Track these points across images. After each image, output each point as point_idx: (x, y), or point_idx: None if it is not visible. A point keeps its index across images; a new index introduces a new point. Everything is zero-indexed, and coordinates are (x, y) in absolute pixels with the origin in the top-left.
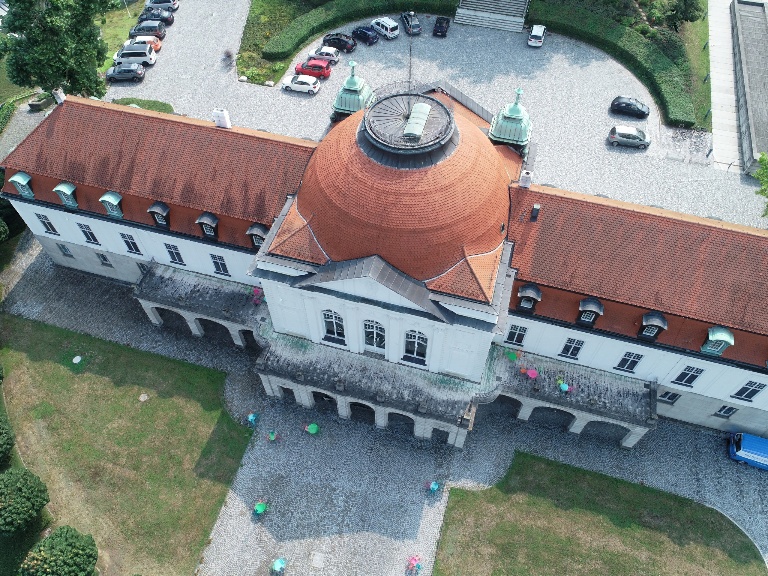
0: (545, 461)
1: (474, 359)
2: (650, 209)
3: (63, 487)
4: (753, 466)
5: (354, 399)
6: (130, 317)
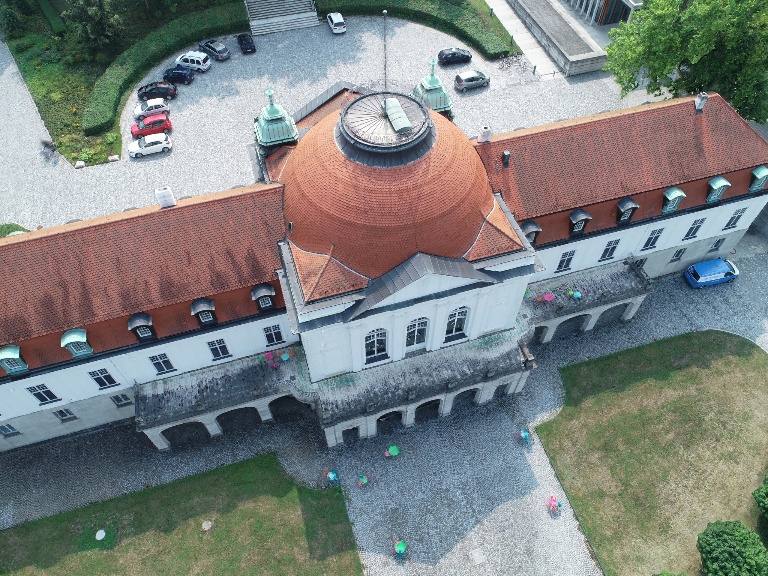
0: (584, 364)
1: (511, 307)
2: (573, 121)
3: None
4: (709, 286)
5: (424, 400)
6: (128, 459)
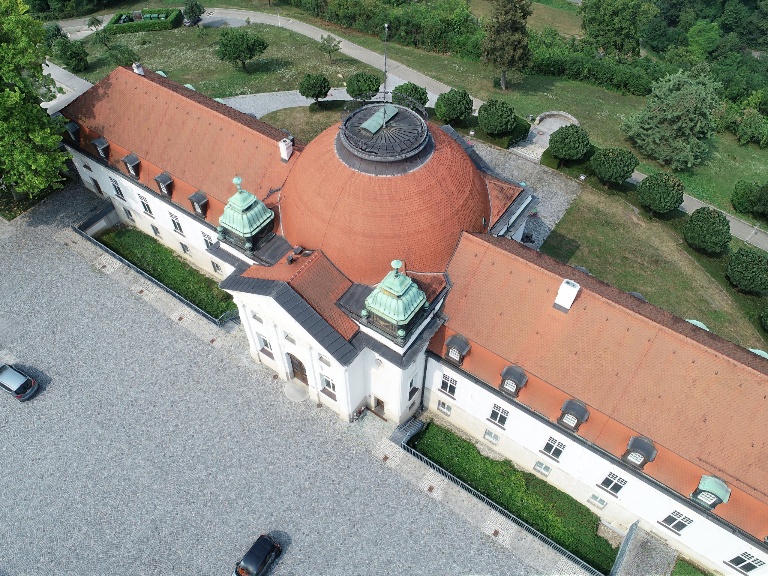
0: None
1: None
2: (191, 143)
3: (679, 261)
4: None
5: None
6: None
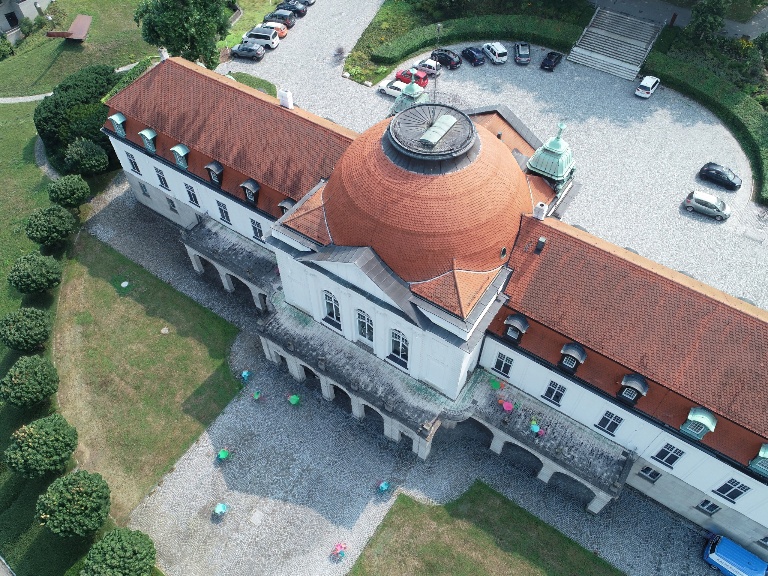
0: (502, 498)
1: (449, 374)
2: (668, 272)
3: (76, 386)
4: (727, 575)
5: (334, 381)
6: (179, 260)
